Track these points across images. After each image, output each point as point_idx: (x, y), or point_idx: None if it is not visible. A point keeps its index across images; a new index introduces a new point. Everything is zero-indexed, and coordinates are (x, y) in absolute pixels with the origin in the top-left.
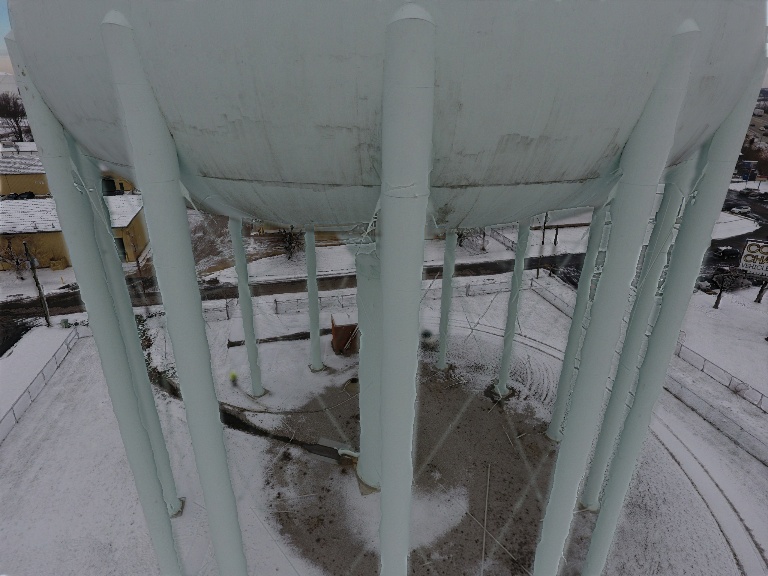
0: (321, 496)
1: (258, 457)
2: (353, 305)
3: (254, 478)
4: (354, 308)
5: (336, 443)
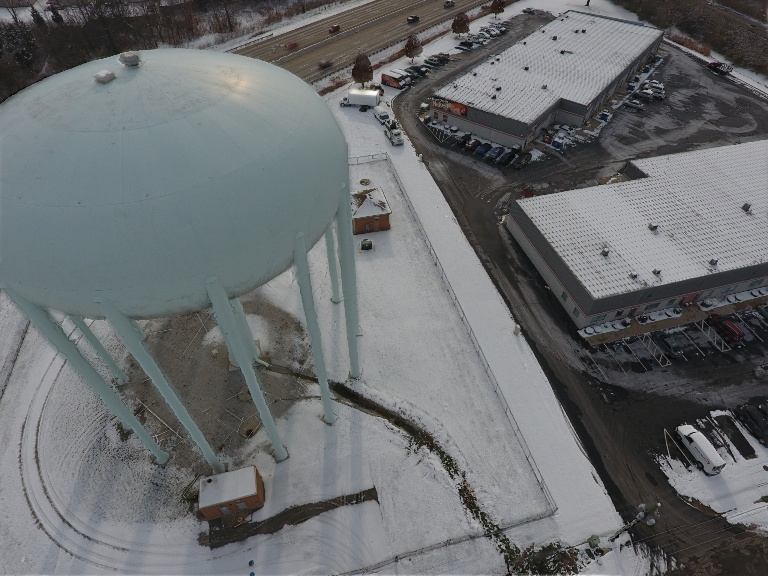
0: (281, 339)
1: None
2: None
3: None
4: None
5: (270, 373)
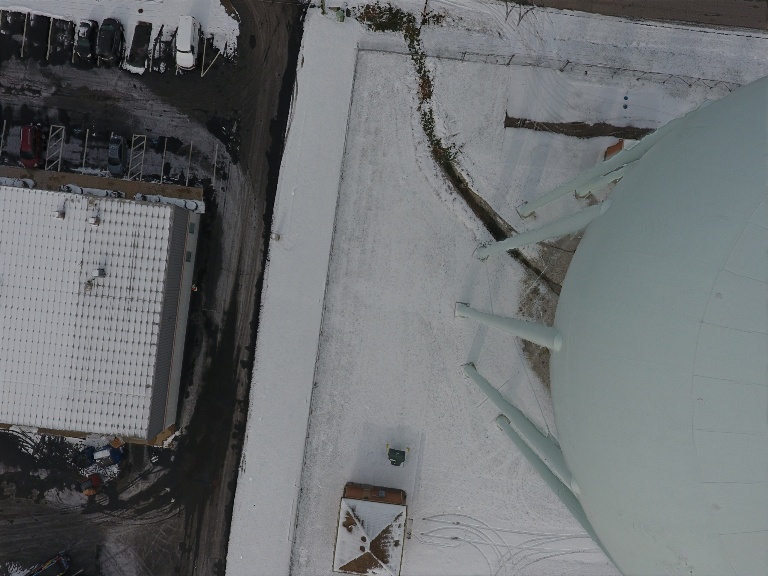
0: None
1: (517, 284)
2: (651, 79)
3: (513, 303)
4: (650, 87)
5: None
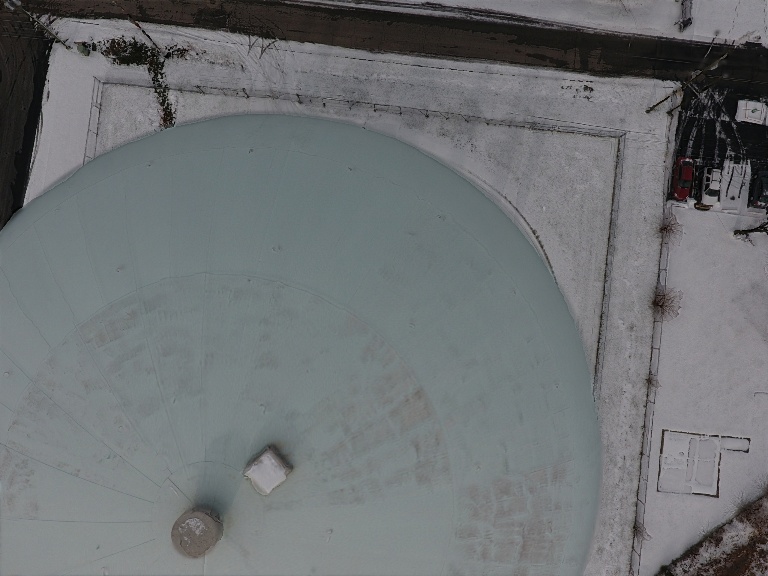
0: None
1: None
2: (388, 110)
3: None
4: (386, 118)
5: None
